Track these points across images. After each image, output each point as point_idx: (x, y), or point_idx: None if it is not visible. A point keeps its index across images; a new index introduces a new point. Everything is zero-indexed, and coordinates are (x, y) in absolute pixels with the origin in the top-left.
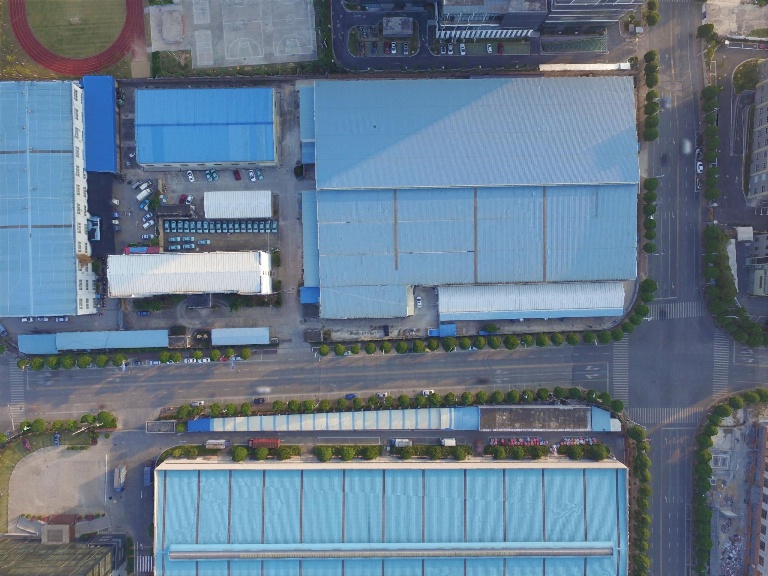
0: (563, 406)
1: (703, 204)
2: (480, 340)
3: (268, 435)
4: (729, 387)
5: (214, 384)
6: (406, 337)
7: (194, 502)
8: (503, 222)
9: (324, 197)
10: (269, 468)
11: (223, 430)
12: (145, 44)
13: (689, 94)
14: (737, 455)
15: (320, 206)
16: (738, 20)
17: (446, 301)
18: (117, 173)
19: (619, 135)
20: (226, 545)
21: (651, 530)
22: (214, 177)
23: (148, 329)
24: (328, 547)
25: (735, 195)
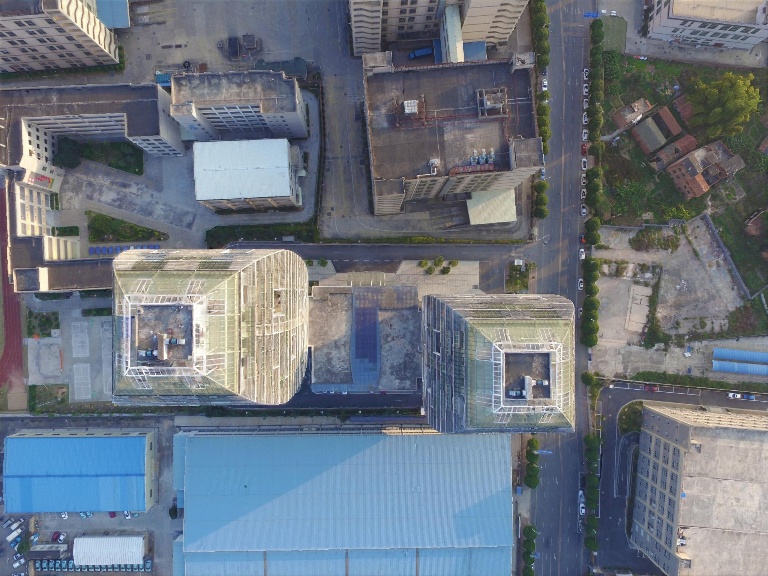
0: None
1: None
2: None
3: None
4: None
5: None
6: None
7: None
8: None
9: (192, 557)
10: None
11: None
12: (23, 375)
13: (573, 434)
14: None
15: (188, 566)
16: (624, 361)
17: None
18: None
19: (494, 497)
20: None
21: None
22: (88, 515)
23: None
24: None
25: (618, 537)
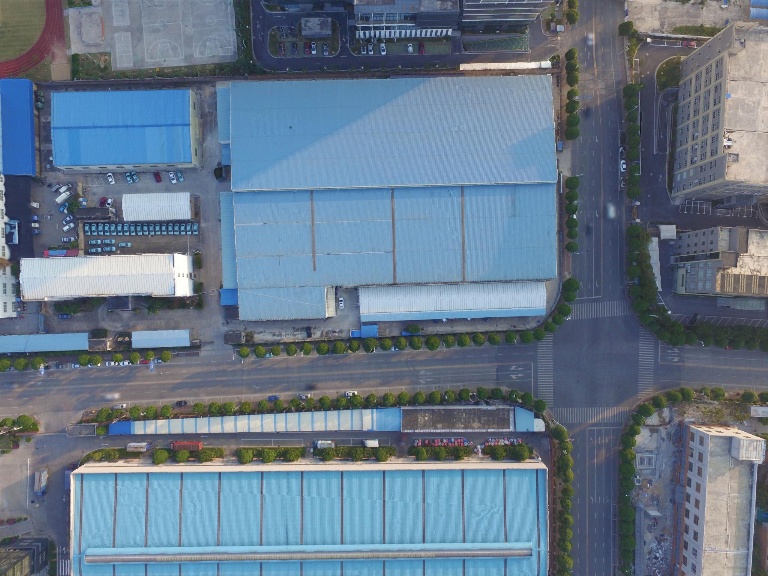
0: (486, 406)
1: (627, 203)
2: (400, 341)
3: (191, 438)
4: (654, 386)
5: (136, 387)
6: (328, 338)
7: (111, 505)
8: (421, 222)
9: (240, 199)
10: (186, 471)
11: (144, 433)
12: (65, 46)
13: (612, 92)
14: (663, 454)
15: (236, 208)
16: (661, 17)
17: (366, 302)
18: (36, 176)
19: (537, 134)
20: (143, 548)
21: (577, 530)
22: (134, 179)
23: (69, 332)
24: (245, 550)
25: (659, 193)
